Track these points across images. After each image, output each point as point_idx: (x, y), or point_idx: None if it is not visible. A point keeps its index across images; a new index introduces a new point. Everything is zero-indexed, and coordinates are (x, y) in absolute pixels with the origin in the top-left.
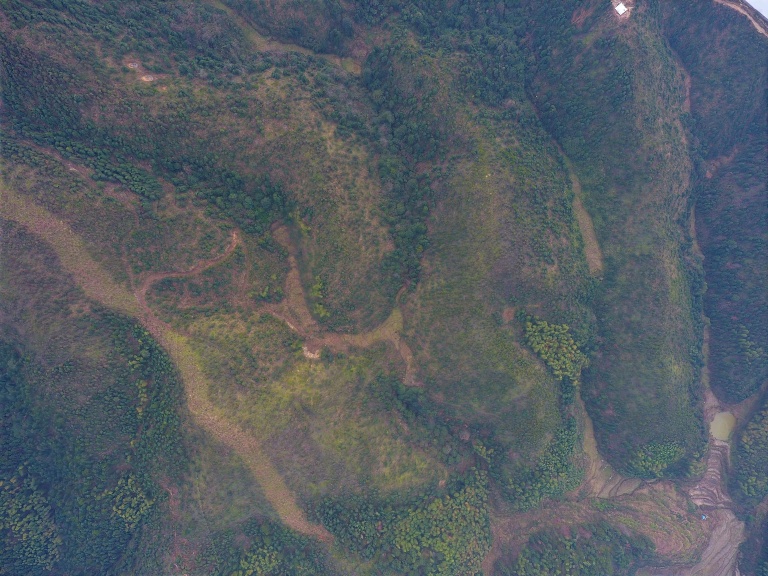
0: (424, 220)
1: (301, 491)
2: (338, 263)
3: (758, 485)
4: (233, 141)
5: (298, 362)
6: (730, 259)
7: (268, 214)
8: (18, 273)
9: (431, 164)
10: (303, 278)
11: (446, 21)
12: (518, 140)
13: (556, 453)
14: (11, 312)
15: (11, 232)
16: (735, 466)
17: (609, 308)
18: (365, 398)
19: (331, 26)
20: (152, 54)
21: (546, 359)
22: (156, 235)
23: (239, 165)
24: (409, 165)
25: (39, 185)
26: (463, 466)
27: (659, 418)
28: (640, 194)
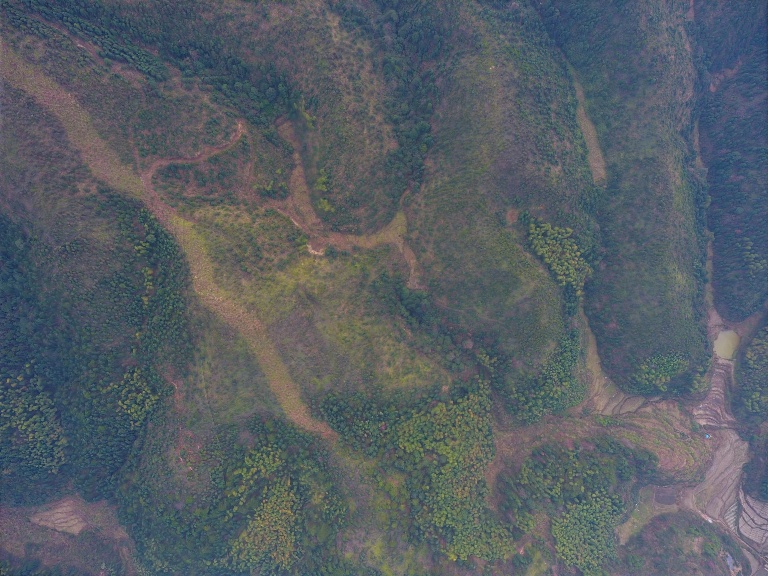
0: (428, 119)
1: (305, 385)
2: (342, 155)
3: (762, 401)
4: (239, 25)
5: (302, 256)
6: (734, 172)
7: (273, 107)
8: (26, 144)
9: (435, 63)
10: (308, 174)
11: None
12: (522, 41)
13: (559, 362)
14: (19, 184)
15: (20, 101)
16: (739, 383)
17: (613, 217)
18: (369, 296)
19: None
20: None
21: (549, 265)
22: (162, 115)
23: (245, 52)
24: (413, 65)
25: (47, 56)
26: (466, 375)
27: (663, 327)
28: (644, 97)
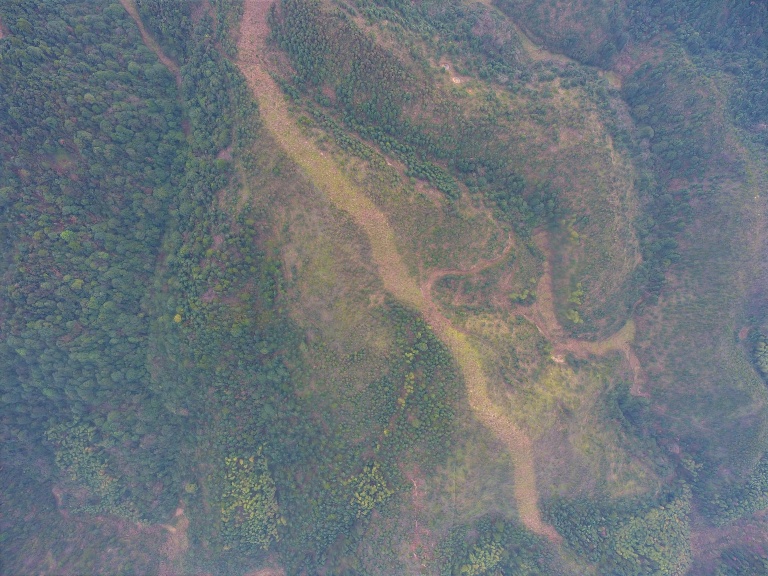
0: (675, 235)
1: (543, 492)
2: (603, 272)
3: None
4: (529, 147)
5: (549, 365)
6: None
7: (536, 219)
8: (340, 261)
9: (687, 181)
10: (557, 284)
11: (711, 42)
12: None
13: (763, 472)
14: (326, 298)
15: (341, 221)
16: None
17: None
18: (603, 405)
19: (608, 40)
20: (458, 57)
21: None
22: (456, 233)
23: (526, 170)
24: (661, 180)
25: (369, 178)
26: (669, 478)
27: None
28: None
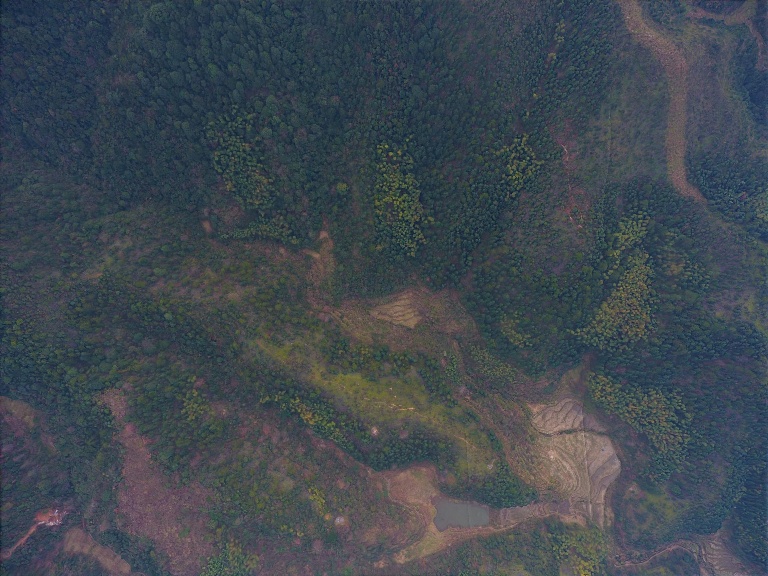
0: None
1: (690, 144)
2: None
3: None
4: None
5: (687, 21)
6: None
7: None
8: None
9: None
10: None
11: None
12: None
13: None
14: None
15: None
16: None
17: None
18: (737, 67)
19: None
20: None
21: None
22: None
23: None
24: None
25: None
26: None
27: None
28: None
